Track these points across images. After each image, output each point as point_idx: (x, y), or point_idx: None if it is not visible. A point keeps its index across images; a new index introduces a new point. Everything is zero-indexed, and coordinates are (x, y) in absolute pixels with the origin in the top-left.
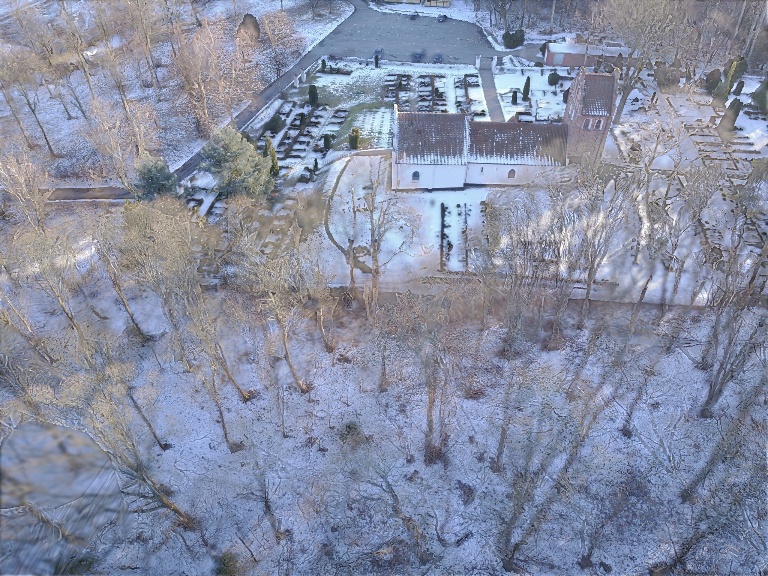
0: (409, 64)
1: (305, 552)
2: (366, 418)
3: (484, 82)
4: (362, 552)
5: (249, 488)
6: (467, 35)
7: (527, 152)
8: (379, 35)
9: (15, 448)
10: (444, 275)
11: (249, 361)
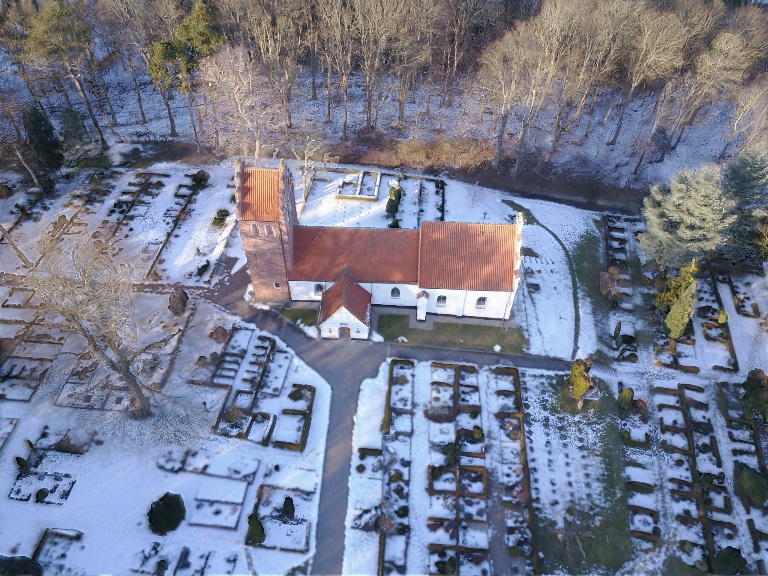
0: None
1: None
2: None
3: None
4: None
5: None
6: None
7: None
8: None
9: None
10: None
11: (575, 142)
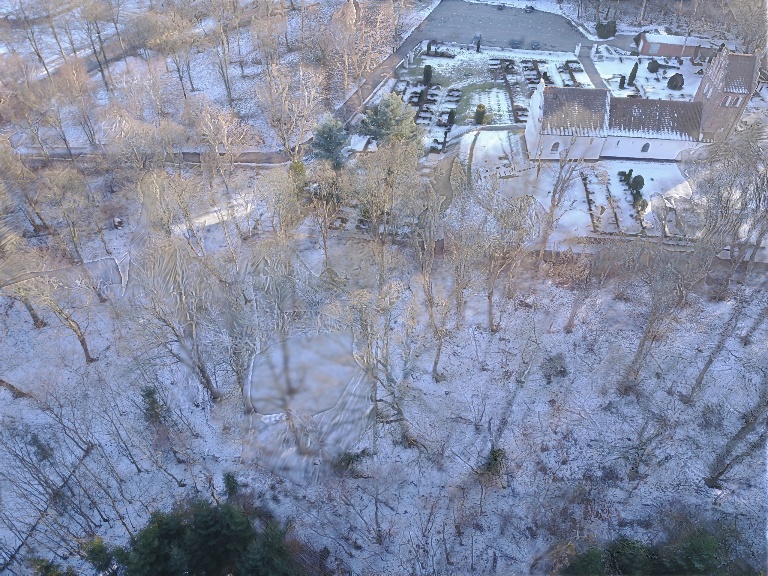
0: (509, 50)
1: (520, 468)
2: (557, 355)
3: (586, 68)
4: (632, 446)
5: (457, 413)
6: (557, 25)
7: (663, 127)
8: (472, 23)
9: (287, 358)
10: (598, 235)
11: (434, 305)
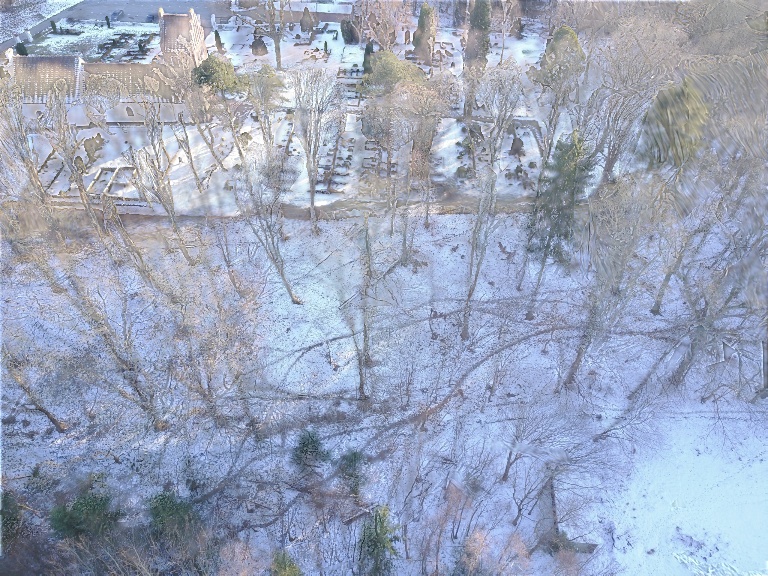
0: (139, 24)
1: None
2: None
3: None
4: None
5: None
6: None
7: (137, 90)
8: None
9: None
10: None
11: None
